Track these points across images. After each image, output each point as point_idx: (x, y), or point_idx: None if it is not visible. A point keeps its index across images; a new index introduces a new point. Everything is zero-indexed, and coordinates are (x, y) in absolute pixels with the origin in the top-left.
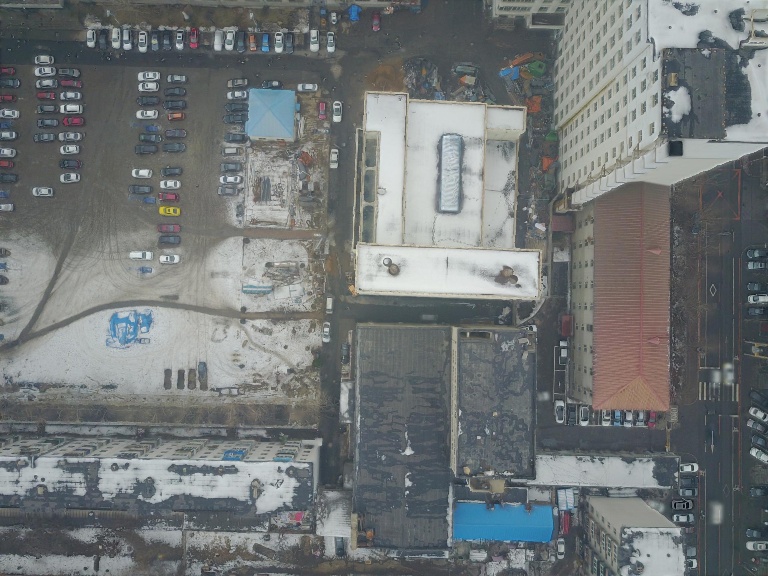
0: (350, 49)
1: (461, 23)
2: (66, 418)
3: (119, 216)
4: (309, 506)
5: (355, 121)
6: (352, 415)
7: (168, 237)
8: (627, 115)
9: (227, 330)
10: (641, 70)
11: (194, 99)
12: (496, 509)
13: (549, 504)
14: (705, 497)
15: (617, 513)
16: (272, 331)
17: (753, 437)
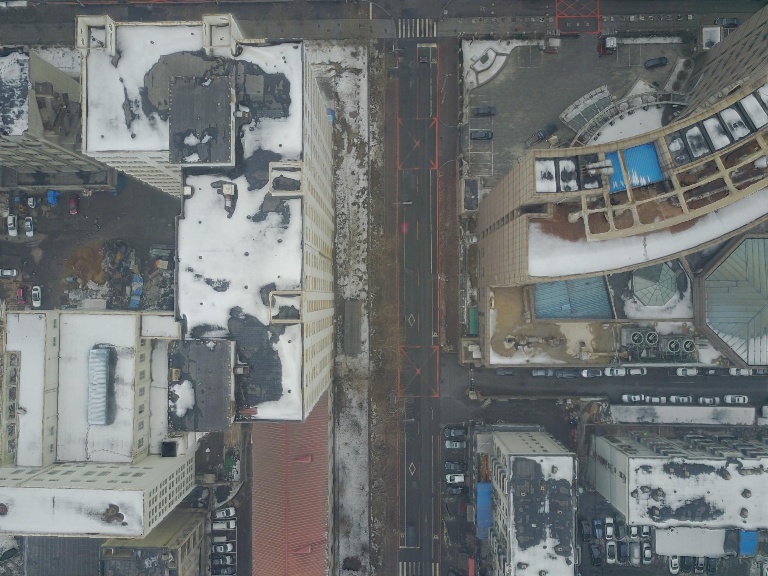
0: (50, 232)
1: (159, 204)
2: None
3: None
4: None
5: (56, 304)
6: None
7: None
8: None
9: None
10: None
11: None
12: None
13: None
14: None
15: None
16: None
17: None
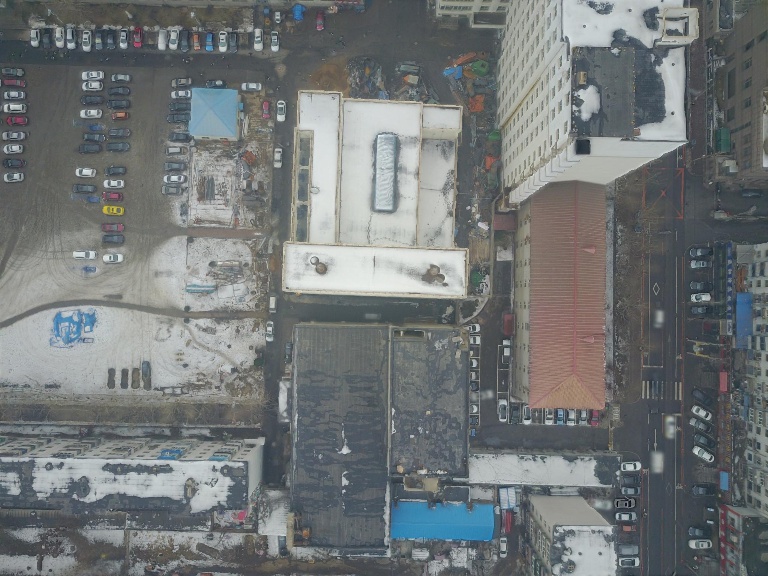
0: (294, 48)
1: (405, 22)
2: (10, 418)
3: (63, 215)
4: (244, 505)
5: None
6: (291, 414)
7: (111, 236)
8: (548, 114)
9: (171, 329)
10: (558, 69)
11: (138, 98)
12: (437, 508)
13: (491, 503)
14: (648, 495)
15: (554, 511)
16: (216, 330)
17: (696, 435)
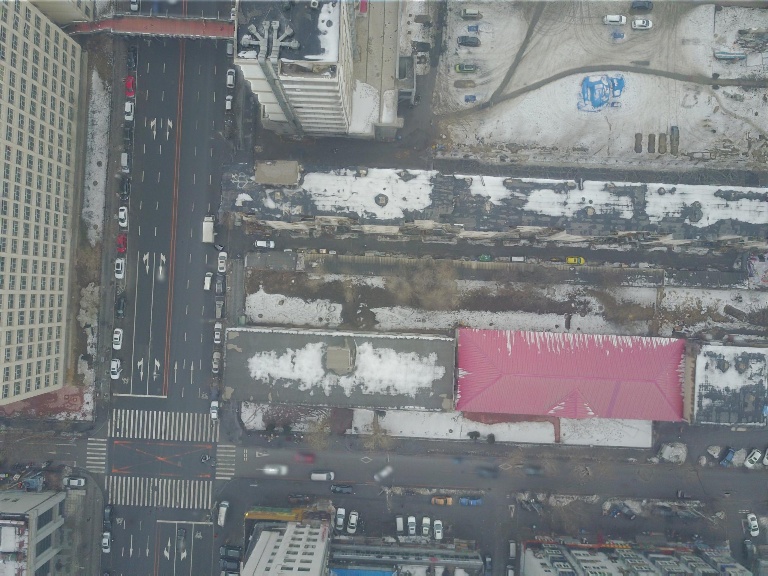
0: None
1: None
2: None
3: None
4: None
5: None
6: None
7: (643, 2)
8: None
9: (698, 96)
10: None
11: None
12: None
13: None
14: None
15: None
16: (744, 97)
17: None
